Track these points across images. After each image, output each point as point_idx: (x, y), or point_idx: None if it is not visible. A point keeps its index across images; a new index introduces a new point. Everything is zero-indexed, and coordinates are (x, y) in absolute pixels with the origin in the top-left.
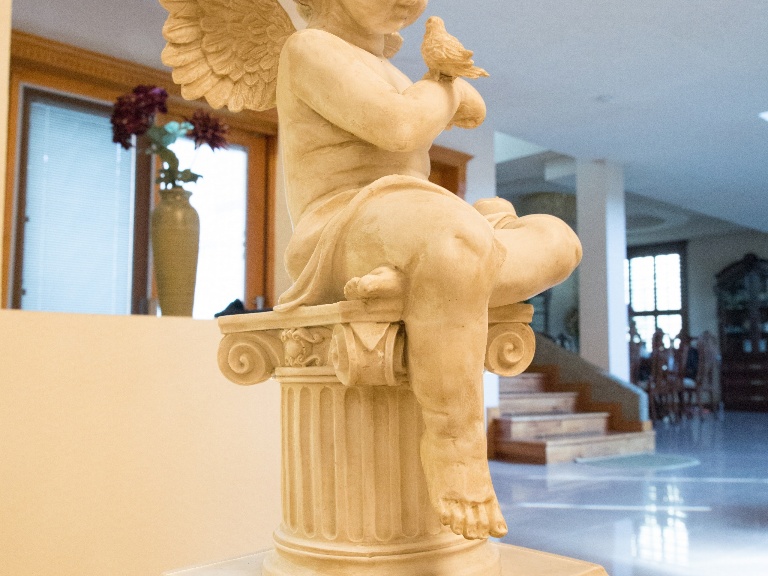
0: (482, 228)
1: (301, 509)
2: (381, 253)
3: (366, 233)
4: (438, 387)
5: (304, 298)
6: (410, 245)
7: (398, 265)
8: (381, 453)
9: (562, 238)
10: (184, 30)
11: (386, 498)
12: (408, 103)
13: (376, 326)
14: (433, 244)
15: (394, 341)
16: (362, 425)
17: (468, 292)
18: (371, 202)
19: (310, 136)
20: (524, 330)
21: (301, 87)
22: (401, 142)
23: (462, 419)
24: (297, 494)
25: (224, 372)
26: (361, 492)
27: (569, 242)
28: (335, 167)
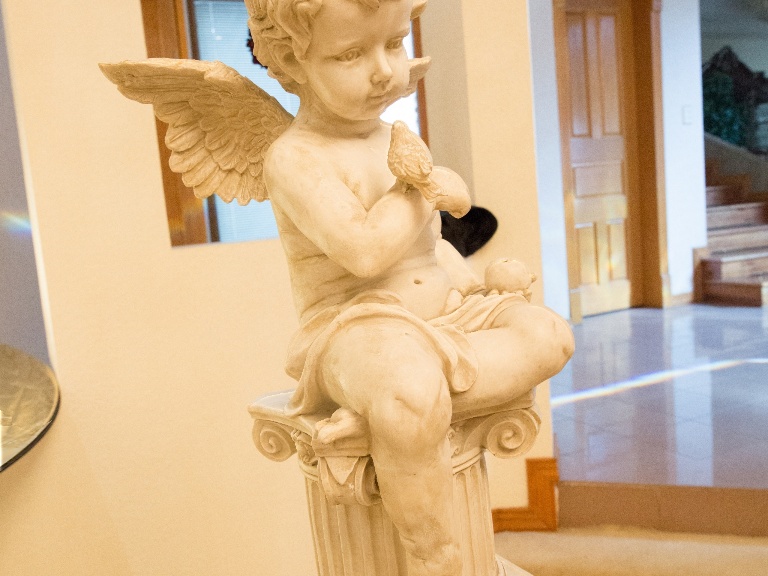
0: (423, 386)
1: None
2: (343, 396)
3: (332, 373)
4: (402, 520)
5: (300, 411)
6: (360, 399)
7: (356, 411)
8: (379, 547)
9: (545, 341)
10: (184, 137)
11: None
12: (366, 235)
13: (346, 460)
14: (376, 405)
15: (363, 475)
16: (360, 523)
17: (412, 449)
18: (339, 336)
19: (297, 247)
20: (524, 415)
21: (280, 206)
22: (363, 273)
23: (428, 546)
24: None
25: (260, 449)
26: None
27: (553, 344)
28: (321, 278)
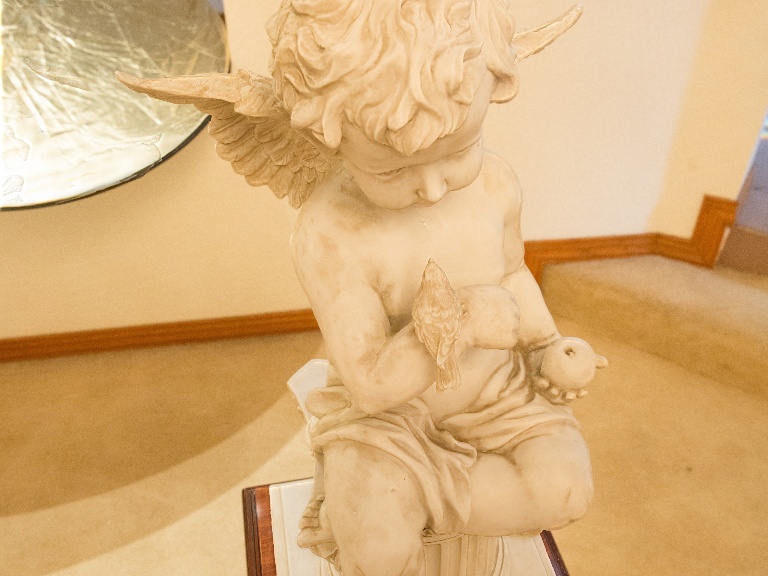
0: (384, 569)
1: None
2: None
3: None
4: None
5: None
6: (334, 537)
7: None
8: None
9: (550, 513)
10: (229, 130)
11: None
12: (369, 387)
13: None
14: (341, 559)
15: None
16: None
17: None
18: (336, 448)
19: None
20: None
21: None
22: None
23: None
24: None
25: None
26: None
27: (559, 517)
28: None
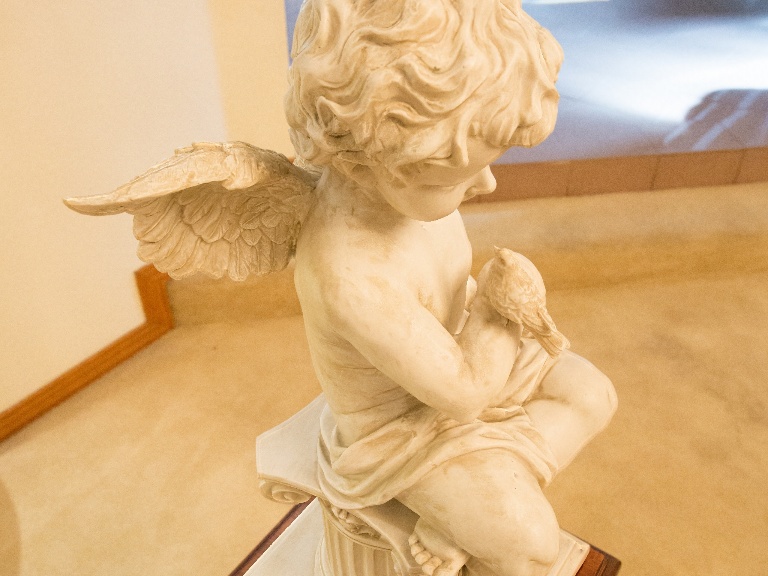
0: (553, 543)
1: None
2: (450, 537)
3: (434, 515)
4: None
5: None
6: (484, 554)
7: None
8: None
9: (604, 418)
10: (162, 224)
11: None
12: (479, 394)
13: None
14: (508, 565)
15: None
16: None
17: None
18: (435, 477)
19: (351, 361)
20: None
21: None
22: None
23: None
24: None
25: (268, 498)
26: None
27: (610, 416)
28: (381, 389)
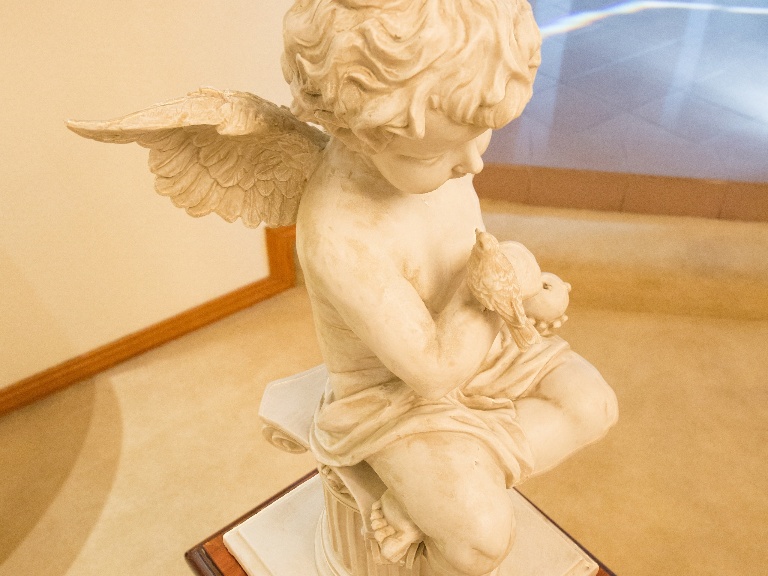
0: (500, 537)
1: (341, 556)
2: None
3: (392, 485)
4: None
5: (336, 466)
6: (431, 532)
7: None
8: None
9: (597, 429)
10: (175, 161)
11: (408, 574)
12: (442, 373)
13: None
14: (451, 548)
15: (414, 556)
16: None
17: None
18: (398, 448)
19: (337, 321)
20: None
21: None
22: (432, 400)
23: None
24: (338, 546)
25: (270, 442)
26: (388, 571)
27: (604, 429)
28: (365, 354)
